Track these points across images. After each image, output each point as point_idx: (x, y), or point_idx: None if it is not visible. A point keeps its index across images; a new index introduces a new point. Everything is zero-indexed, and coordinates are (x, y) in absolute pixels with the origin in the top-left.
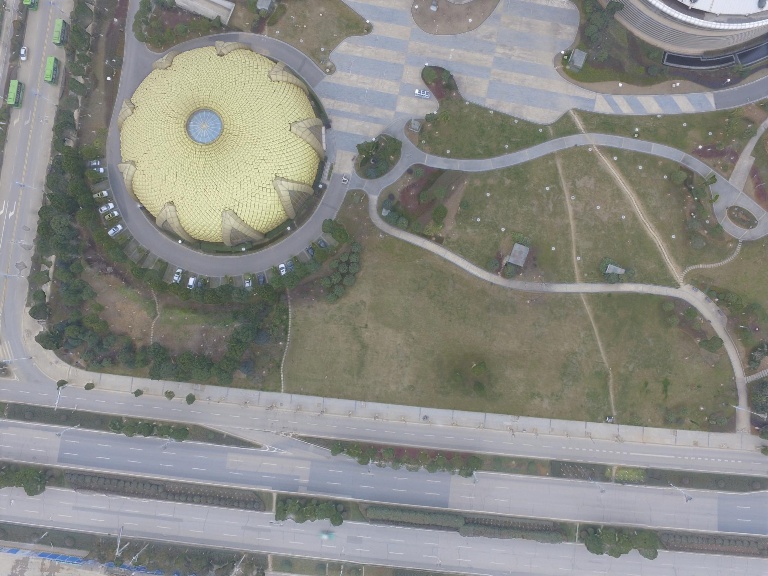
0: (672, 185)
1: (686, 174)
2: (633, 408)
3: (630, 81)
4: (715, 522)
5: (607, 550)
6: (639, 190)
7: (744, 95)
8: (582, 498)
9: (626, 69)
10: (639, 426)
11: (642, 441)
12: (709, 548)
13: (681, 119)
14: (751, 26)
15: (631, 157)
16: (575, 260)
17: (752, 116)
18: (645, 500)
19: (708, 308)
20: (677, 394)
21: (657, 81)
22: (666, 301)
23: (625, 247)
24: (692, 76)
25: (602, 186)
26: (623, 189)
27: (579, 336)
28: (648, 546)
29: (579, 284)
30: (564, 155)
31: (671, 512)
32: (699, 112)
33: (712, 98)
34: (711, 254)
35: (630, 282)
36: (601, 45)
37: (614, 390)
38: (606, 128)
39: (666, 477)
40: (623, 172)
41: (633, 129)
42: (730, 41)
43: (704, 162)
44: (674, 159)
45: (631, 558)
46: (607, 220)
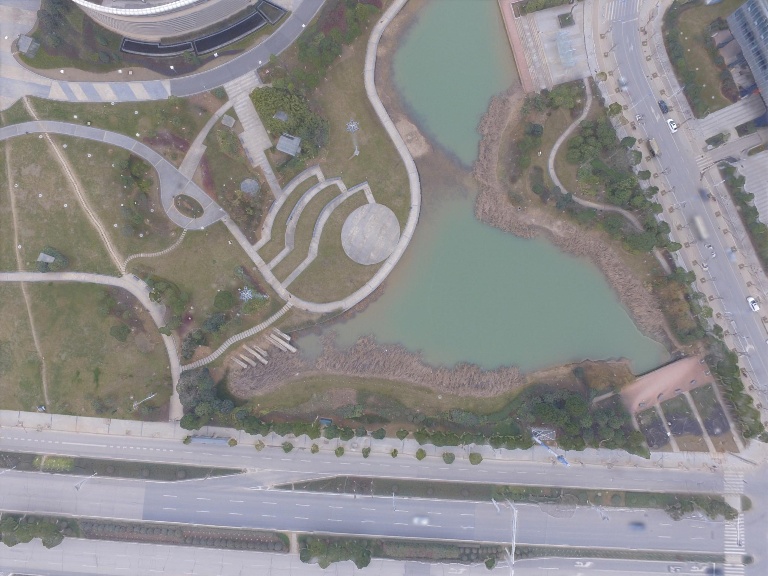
0: (119, 173)
1: (125, 162)
2: (65, 397)
3: (84, 68)
4: (140, 511)
5: (2, 539)
6: (84, 178)
7: (200, 83)
8: (9, 487)
9: (81, 55)
10: (73, 415)
11: (75, 430)
12: (130, 536)
13: (134, 107)
14: (149, 12)
15: (82, 145)
16: (17, 249)
17: (207, 104)
18: (72, 489)
19: (148, 297)
20: (108, 383)
21: (113, 68)
22: (106, 290)
23: (67, 236)
24: (146, 63)
25: (47, 174)
26: (68, 177)
27: (13, 325)
28: (45, 535)
29: (20, 273)
30: (15, 142)
31: (97, 501)
32: (154, 100)
33: (168, 86)
34: (153, 243)
35: (73, 271)
36: (57, 31)
37: (47, 379)
38: (59, 115)
39: (92, 466)
40: (71, 160)
41: (85, 116)
42: (173, 28)
43: (155, 150)
44: (126, 147)
45: (53, 547)
46: (49, 208)
